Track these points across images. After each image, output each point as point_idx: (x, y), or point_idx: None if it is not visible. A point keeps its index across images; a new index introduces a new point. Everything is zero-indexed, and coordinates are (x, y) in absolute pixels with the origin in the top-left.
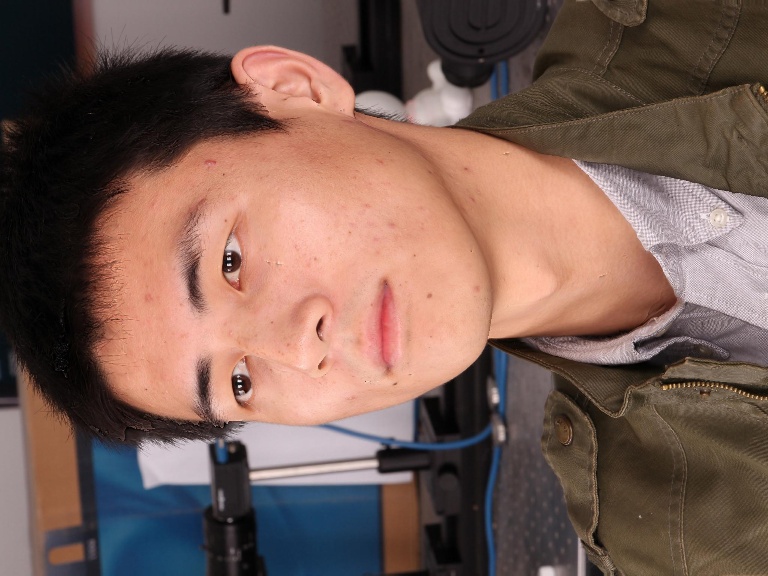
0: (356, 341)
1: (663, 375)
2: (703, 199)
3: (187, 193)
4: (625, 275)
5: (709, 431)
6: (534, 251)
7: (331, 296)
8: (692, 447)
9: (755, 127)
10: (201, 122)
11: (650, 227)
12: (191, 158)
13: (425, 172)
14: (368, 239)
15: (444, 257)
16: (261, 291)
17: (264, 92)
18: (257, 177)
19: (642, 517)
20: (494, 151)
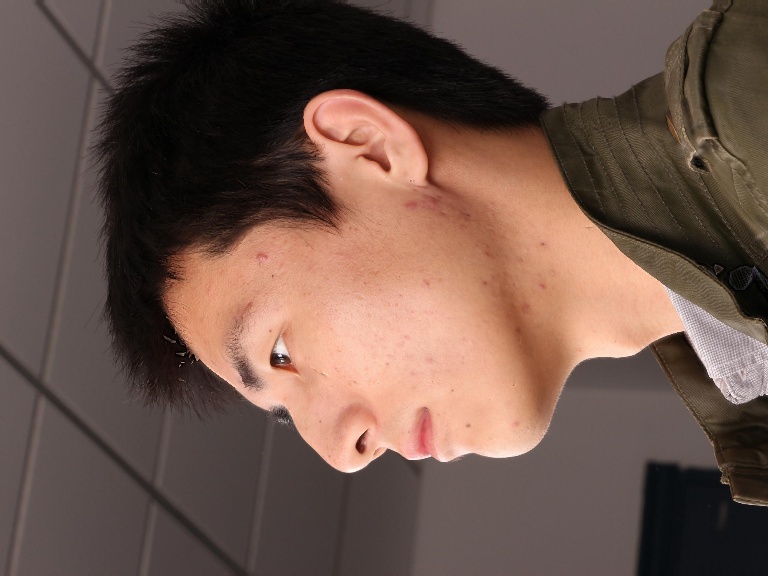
0: None
1: None
2: None
3: (238, 290)
4: None
5: None
6: (611, 329)
7: (374, 410)
8: None
9: None
10: (258, 203)
11: (713, 360)
12: (245, 247)
13: (477, 288)
14: (405, 372)
15: (483, 393)
16: (314, 383)
17: (334, 152)
18: (301, 291)
19: None
20: (576, 223)
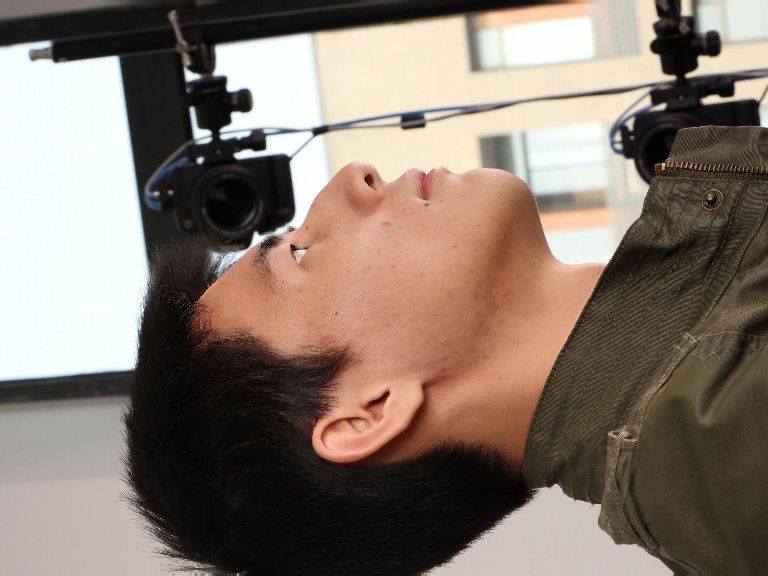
0: None
1: None
2: None
3: None
4: None
5: None
6: None
7: None
8: None
9: None
10: None
11: None
12: None
13: None
14: None
15: None
16: None
17: None
18: None
19: None
20: None
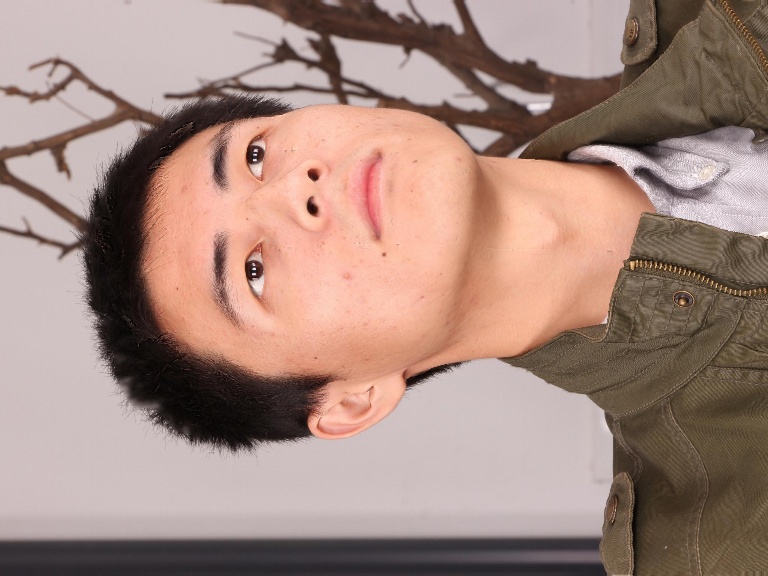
0: (344, 189)
1: None
2: (696, 164)
3: None
4: None
5: (715, 412)
6: (540, 204)
7: (331, 164)
8: (712, 462)
9: (716, 35)
10: (269, 112)
11: (635, 157)
12: None
13: None
14: None
15: (435, 143)
16: (276, 175)
17: None
18: None
19: (667, 546)
20: None
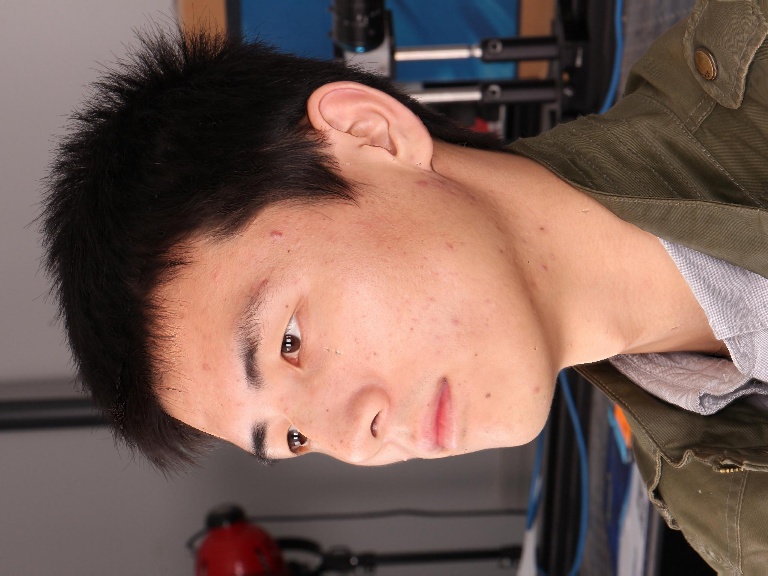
0: (411, 435)
1: (721, 462)
2: None
3: (250, 269)
4: (699, 323)
5: None
6: (604, 317)
7: (389, 389)
8: None
9: None
10: (270, 183)
11: (723, 319)
12: (257, 227)
13: (496, 254)
14: (430, 337)
15: (506, 357)
16: (319, 373)
17: (339, 139)
18: (322, 261)
19: (702, 493)
20: (573, 207)
